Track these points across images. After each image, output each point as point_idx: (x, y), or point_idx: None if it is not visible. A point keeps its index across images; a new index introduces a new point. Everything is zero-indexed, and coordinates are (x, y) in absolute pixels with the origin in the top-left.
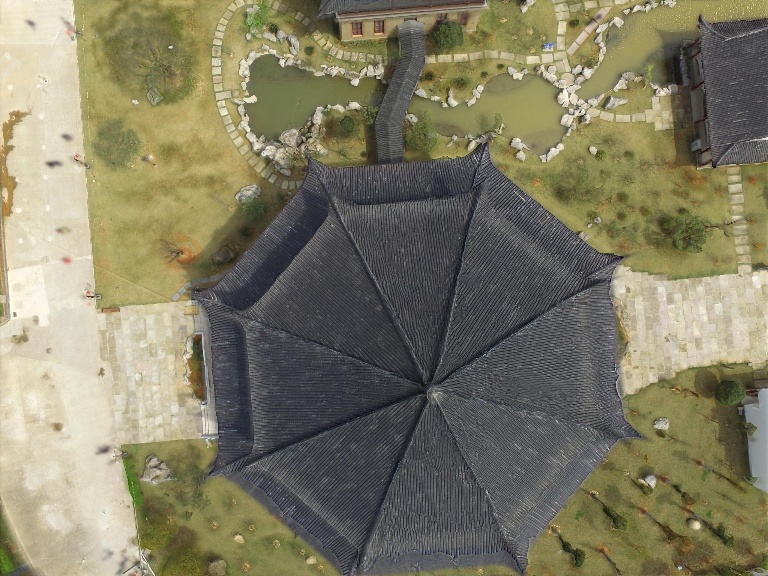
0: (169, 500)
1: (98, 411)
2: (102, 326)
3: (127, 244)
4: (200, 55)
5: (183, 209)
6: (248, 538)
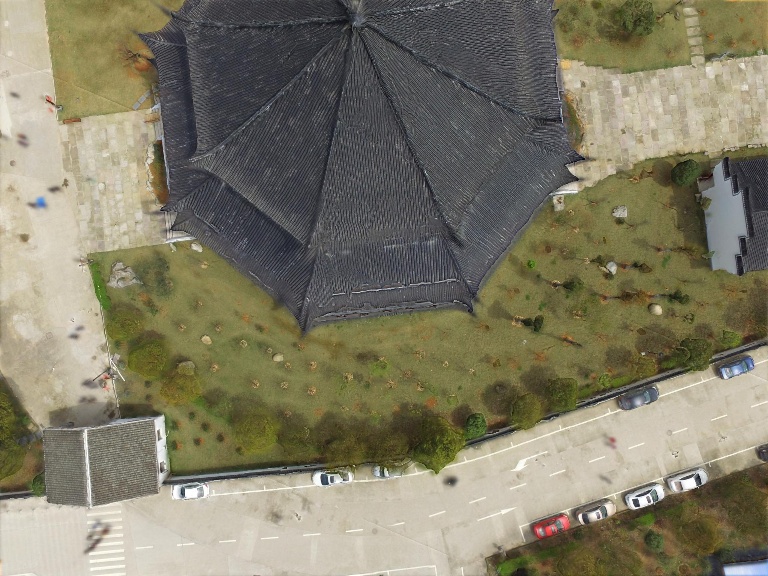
0: (136, 305)
1: (63, 221)
2: (64, 138)
3: (86, 55)
4: None
5: (140, 18)
6: (215, 339)
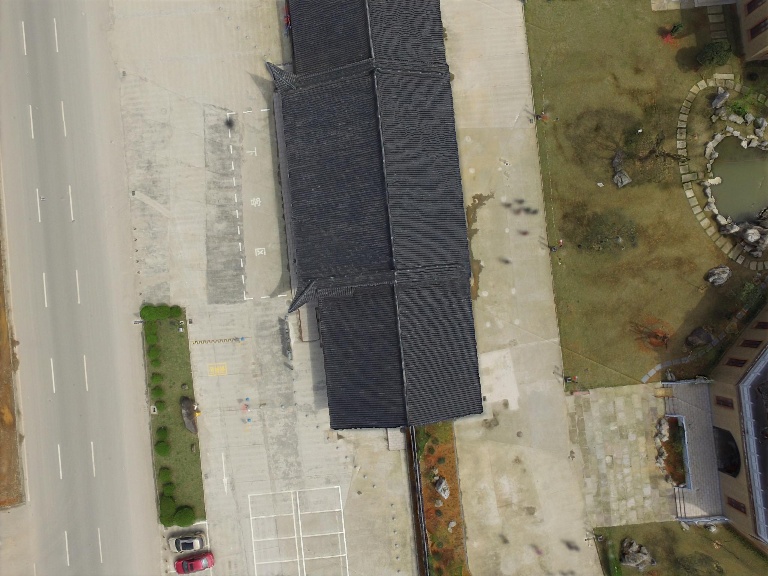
0: None
1: (569, 494)
2: (571, 409)
3: (595, 326)
4: (665, 137)
5: (652, 291)
6: None
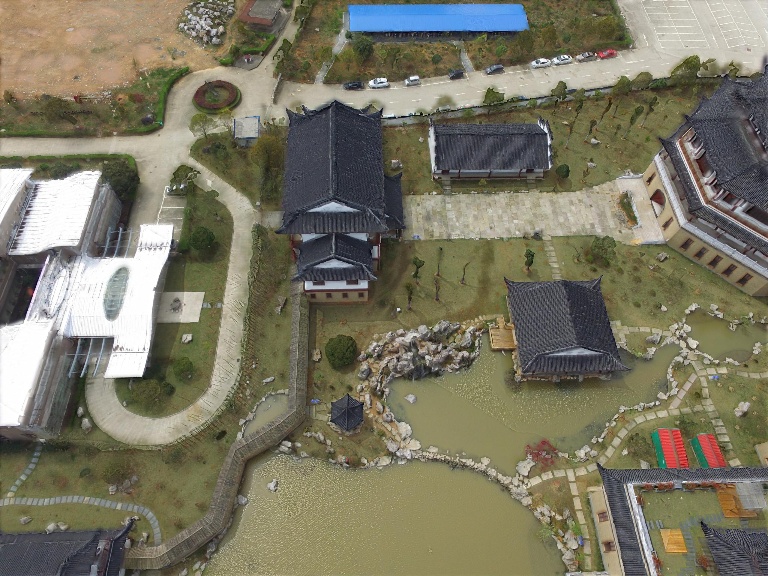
0: None
1: None
2: None
3: None
4: None
5: None
6: None
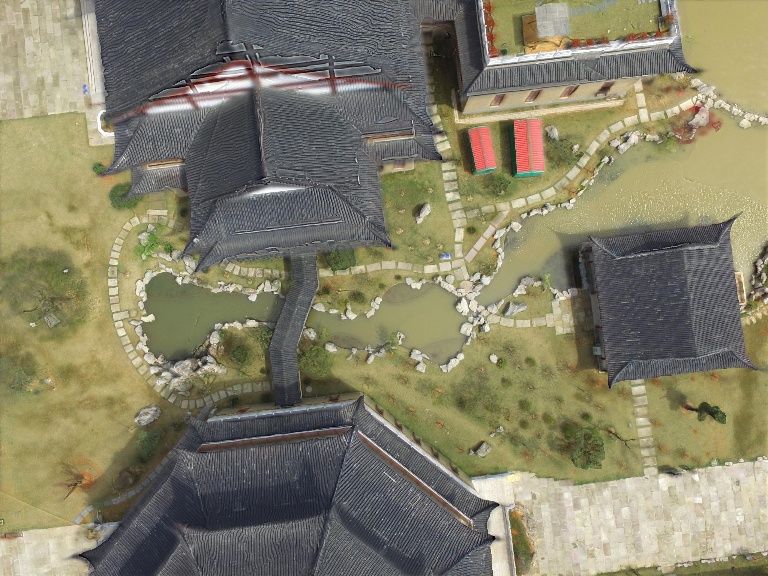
0: None
1: None
2: (6, 551)
3: (28, 468)
4: (96, 276)
5: (83, 432)
6: None
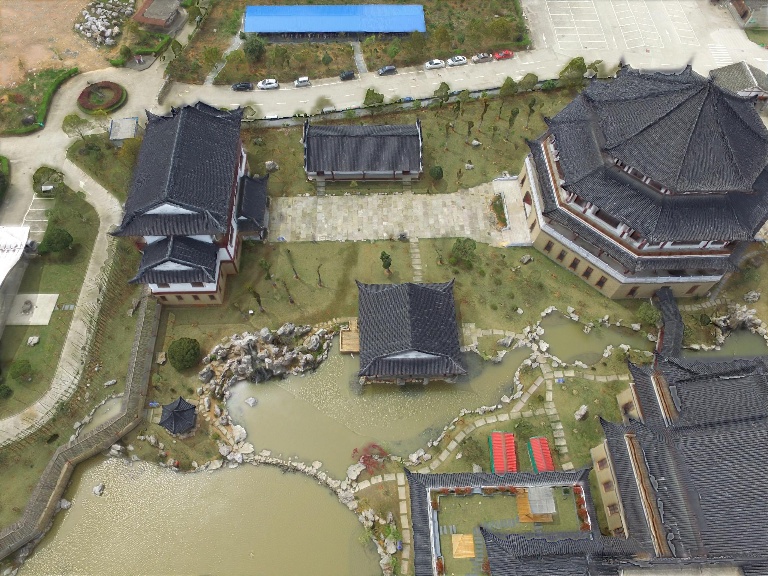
0: None
1: None
2: None
3: None
4: None
5: None
6: None
